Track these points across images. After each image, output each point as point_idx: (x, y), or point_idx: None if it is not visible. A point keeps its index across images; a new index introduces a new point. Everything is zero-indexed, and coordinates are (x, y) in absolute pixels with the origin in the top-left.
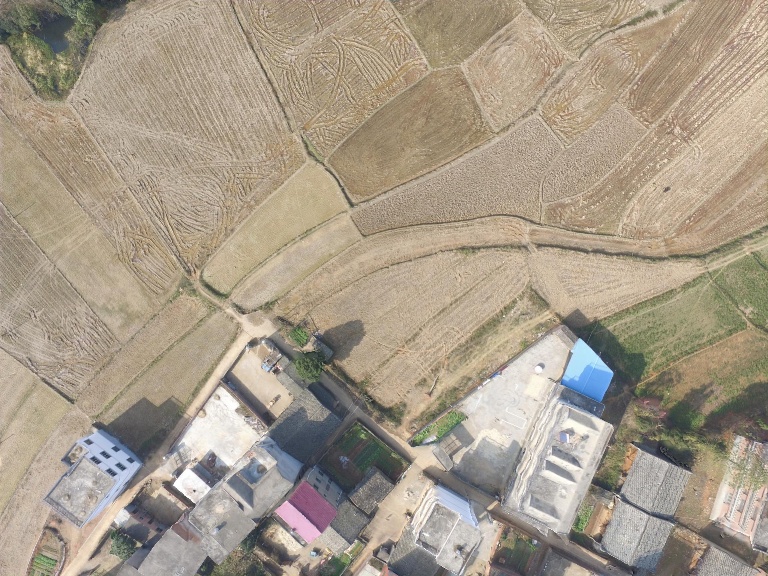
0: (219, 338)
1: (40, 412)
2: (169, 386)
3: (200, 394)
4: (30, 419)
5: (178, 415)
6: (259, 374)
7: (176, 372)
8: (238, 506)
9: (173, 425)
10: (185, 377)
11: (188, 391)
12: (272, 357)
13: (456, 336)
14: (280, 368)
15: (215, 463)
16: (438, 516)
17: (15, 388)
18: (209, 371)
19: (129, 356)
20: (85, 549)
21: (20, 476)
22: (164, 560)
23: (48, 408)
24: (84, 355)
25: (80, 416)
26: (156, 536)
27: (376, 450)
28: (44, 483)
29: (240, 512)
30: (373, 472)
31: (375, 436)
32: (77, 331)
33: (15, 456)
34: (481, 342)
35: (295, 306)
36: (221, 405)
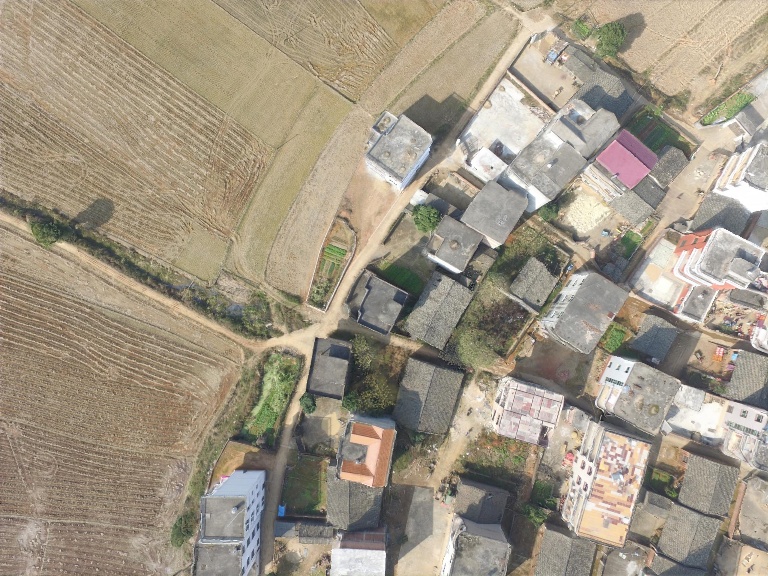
0: (499, 36)
1: (323, 113)
2: (451, 83)
3: (483, 88)
4: (313, 120)
5: (462, 108)
6: (541, 68)
7: (457, 69)
8: (569, 144)
9: (458, 118)
10: (466, 74)
11: (469, 88)
12: (559, 45)
13: (738, 25)
14: (566, 57)
15: (502, 151)
16: (763, 156)
17: (297, 91)
18: (491, 66)
19: (409, 57)
20: (375, 238)
21: (305, 174)
22: (487, 208)
23: (331, 109)
24: (364, 58)
25: (363, 115)
26: (456, 211)
27: (663, 134)
28: (330, 179)
29: (571, 149)
30: (668, 147)
31: (664, 118)
32: (356, 35)
33: (300, 155)
34: (765, 29)
35: (574, 3)
36: (506, 96)
